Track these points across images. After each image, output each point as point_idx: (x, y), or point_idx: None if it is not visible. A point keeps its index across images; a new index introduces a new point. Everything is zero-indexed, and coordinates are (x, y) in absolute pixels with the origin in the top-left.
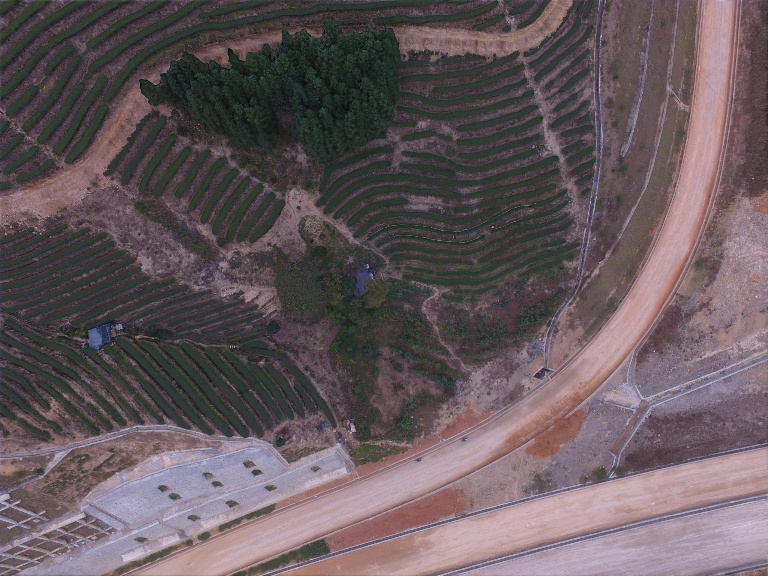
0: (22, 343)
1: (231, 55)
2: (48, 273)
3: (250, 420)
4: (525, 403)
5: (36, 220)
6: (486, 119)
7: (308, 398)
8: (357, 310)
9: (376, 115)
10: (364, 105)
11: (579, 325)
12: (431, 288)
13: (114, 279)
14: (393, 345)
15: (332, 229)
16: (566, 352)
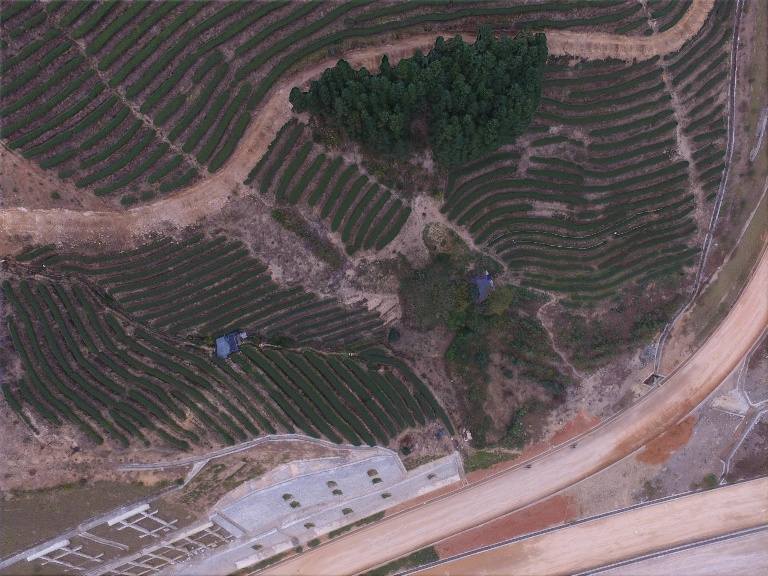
0: (153, 352)
1: (385, 62)
2: (182, 282)
3: (375, 429)
4: (635, 409)
5: (175, 229)
6: (620, 124)
7: (428, 406)
8: (477, 317)
9: (519, 121)
10: (511, 112)
11: (691, 331)
12: (548, 294)
13: (245, 288)
14: (505, 352)
15: (457, 236)
16: (677, 358)
